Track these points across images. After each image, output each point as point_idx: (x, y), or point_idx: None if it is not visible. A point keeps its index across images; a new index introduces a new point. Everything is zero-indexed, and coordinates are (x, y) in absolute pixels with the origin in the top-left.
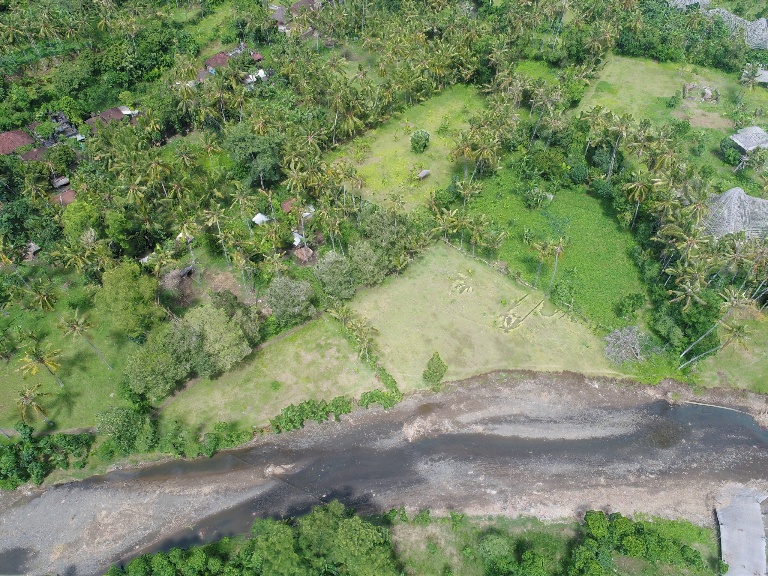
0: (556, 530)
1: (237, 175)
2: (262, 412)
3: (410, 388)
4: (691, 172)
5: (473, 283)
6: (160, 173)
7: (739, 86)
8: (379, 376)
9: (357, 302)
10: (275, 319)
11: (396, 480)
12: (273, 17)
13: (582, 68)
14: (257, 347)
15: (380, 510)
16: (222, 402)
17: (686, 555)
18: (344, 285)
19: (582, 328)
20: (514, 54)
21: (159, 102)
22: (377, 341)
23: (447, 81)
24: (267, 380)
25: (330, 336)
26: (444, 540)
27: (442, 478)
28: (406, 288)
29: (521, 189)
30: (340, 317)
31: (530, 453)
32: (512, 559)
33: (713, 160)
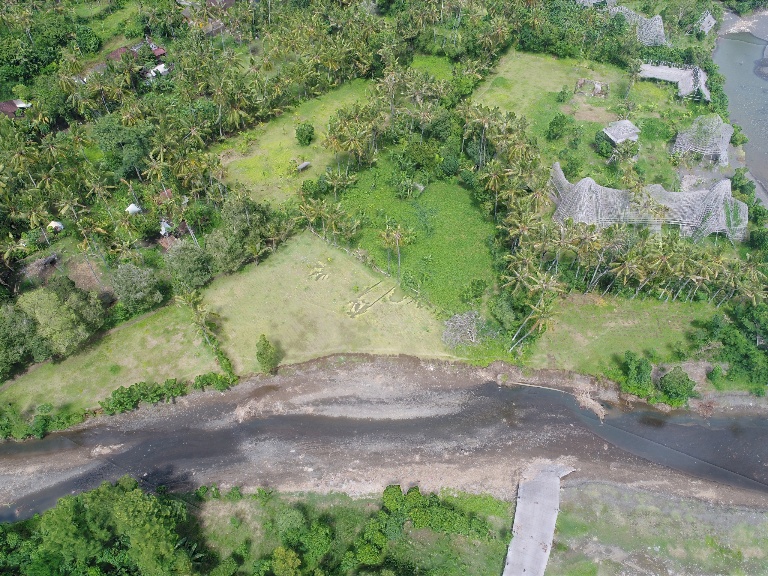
0: (362, 505)
1: (112, 166)
2: (97, 395)
3: (247, 371)
4: (535, 162)
5: (330, 271)
6: (32, 164)
7: (631, 82)
8: (218, 360)
9: (213, 289)
10: (123, 305)
11: (218, 459)
12: (184, 13)
13: (474, 63)
14: (105, 333)
15: (196, 487)
16: (60, 385)
17: (473, 526)
18: (196, 272)
19: (426, 313)
20: (404, 49)
21: (46, 95)
22: (224, 326)
23: (345, 76)
24: (108, 364)
25: (179, 322)
26: (251, 515)
27: (263, 457)
28: (264, 276)
29: (394, 180)
30: (186, 303)
31: (354, 432)
32: (304, 531)
33: (589, 153)
